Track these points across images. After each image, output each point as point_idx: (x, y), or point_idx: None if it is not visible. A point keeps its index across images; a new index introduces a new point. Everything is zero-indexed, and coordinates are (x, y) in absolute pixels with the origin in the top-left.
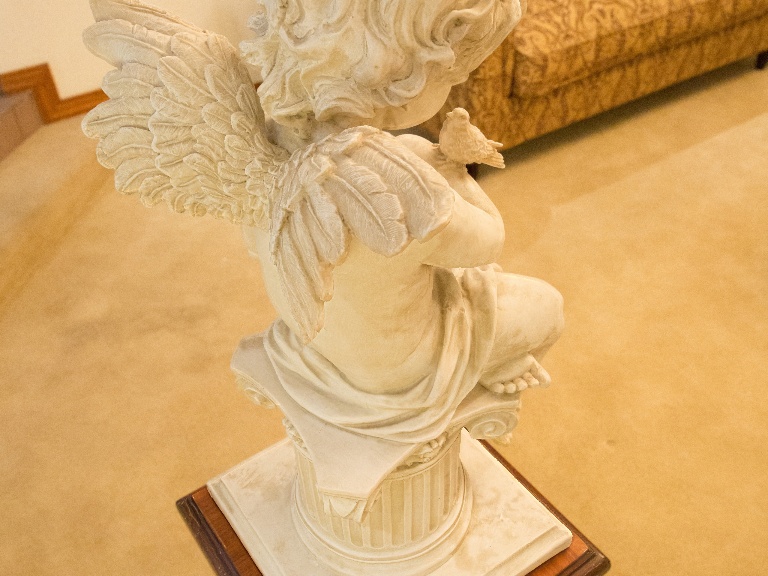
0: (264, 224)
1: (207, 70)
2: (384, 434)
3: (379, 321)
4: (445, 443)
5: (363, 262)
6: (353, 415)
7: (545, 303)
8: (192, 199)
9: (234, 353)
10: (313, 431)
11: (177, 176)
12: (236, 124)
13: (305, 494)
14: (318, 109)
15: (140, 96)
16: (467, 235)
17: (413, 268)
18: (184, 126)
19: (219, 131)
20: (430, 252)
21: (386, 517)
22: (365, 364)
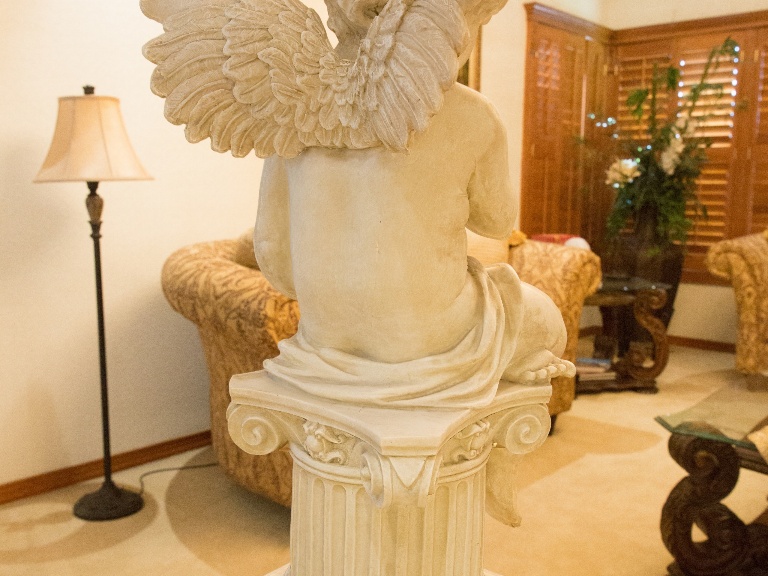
0: (331, 120)
1: None
2: (434, 400)
3: (436, 235)
4: (483, 448)
5: (431, 147)
6: (396, 386)
7: None
8: (245, 124)
9: (231, 380)
10: (351, 411)
11: (246, 76)
12: (311, 25)
13: (311, 573)
14: None
15: (211, 17)
16: None
17: (469, 170)
18: (260, 28)
19: (295, 30)
20: (486, 148)
21: (427, 559)
22: (415, 302)
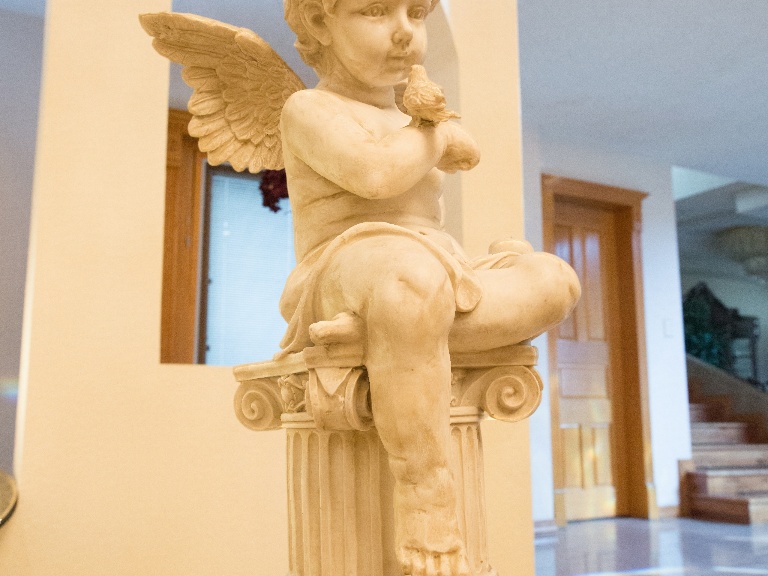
0: None
1: None
2: None
3: None
4: None
5: None
6: None
7: (376, 252)
8: None
9: None
10: None
11: None
12: None
13: None
14: None
15: None
16: (303, 125)
17: None
18: None
19: None
20: None
21: None
22: None
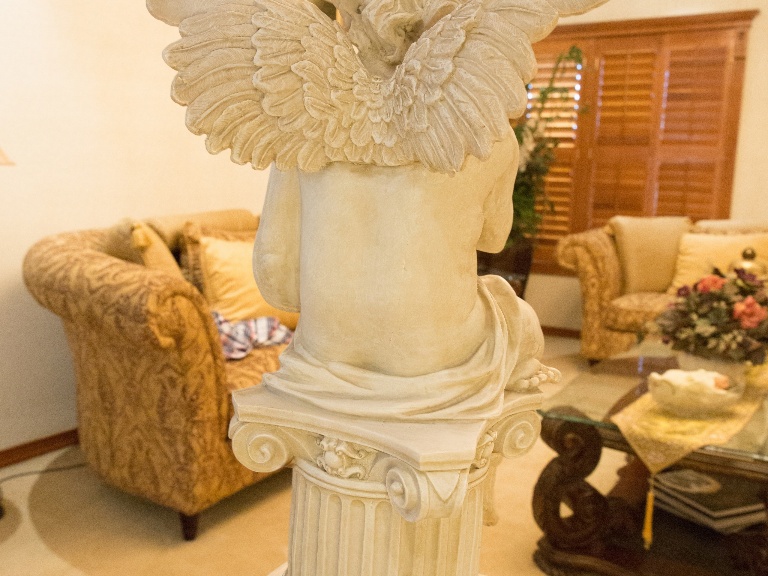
0: (363, 137)
1: (306, 3)
2: (454, 413)
3: (458, 252)
4: None
5: None
6: (416, 400)
7: None
8: (269, 136)
9: (235, 397)
10: (376, 427)
11: (279, 88)
12: (342, 40)
13: None
14: (433, 9)
15: (236, 24)
16: None
17: (488, 189)
18: (291, 40)
19: (327, 43)
20: (505, 168)
21: (441, 567)
22: (437, 318)
